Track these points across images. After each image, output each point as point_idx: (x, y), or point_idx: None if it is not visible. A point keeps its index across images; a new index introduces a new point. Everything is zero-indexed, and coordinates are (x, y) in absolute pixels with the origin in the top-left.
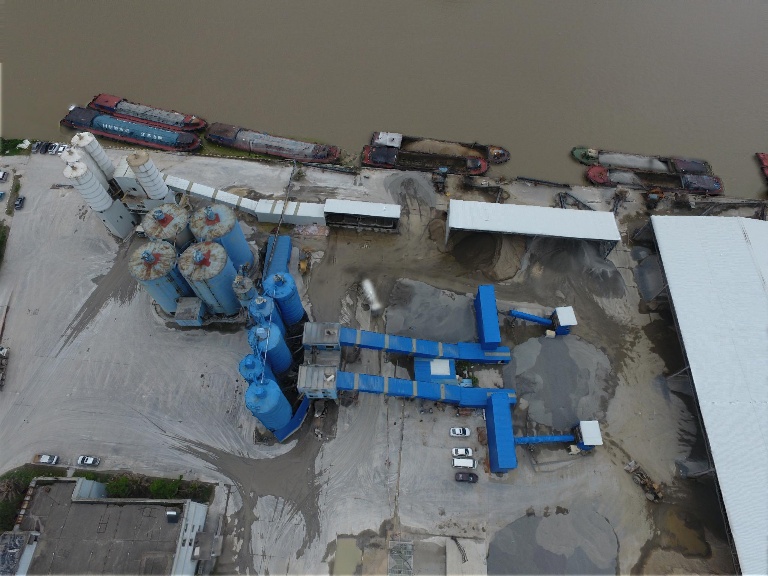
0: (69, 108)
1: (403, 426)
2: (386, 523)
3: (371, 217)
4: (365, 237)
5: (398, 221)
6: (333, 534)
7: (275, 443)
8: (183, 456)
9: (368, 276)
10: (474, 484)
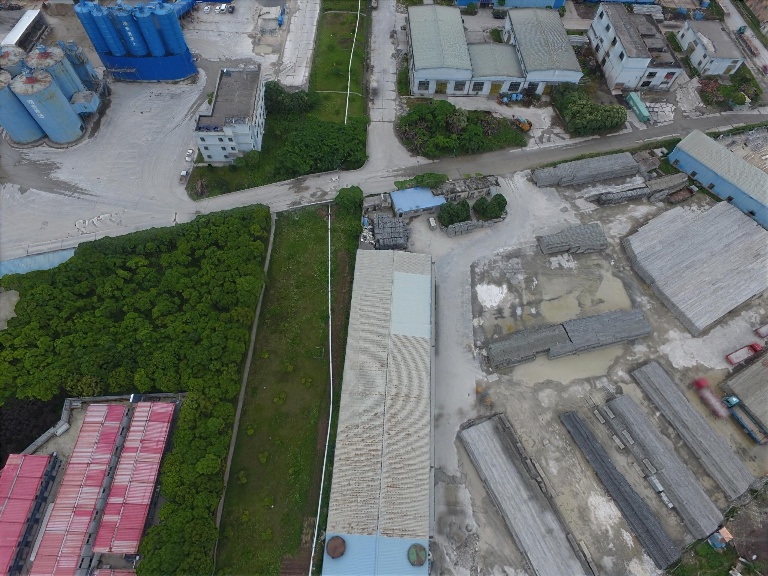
0: None
1: (199, 29)
2: (249, 36)
3: (31, 30)
4: (48, 44)
5: (42, 15)
6: (252, 53)
7: (198, 76)
8: None
9: (86, 42)
10: (235, 8)
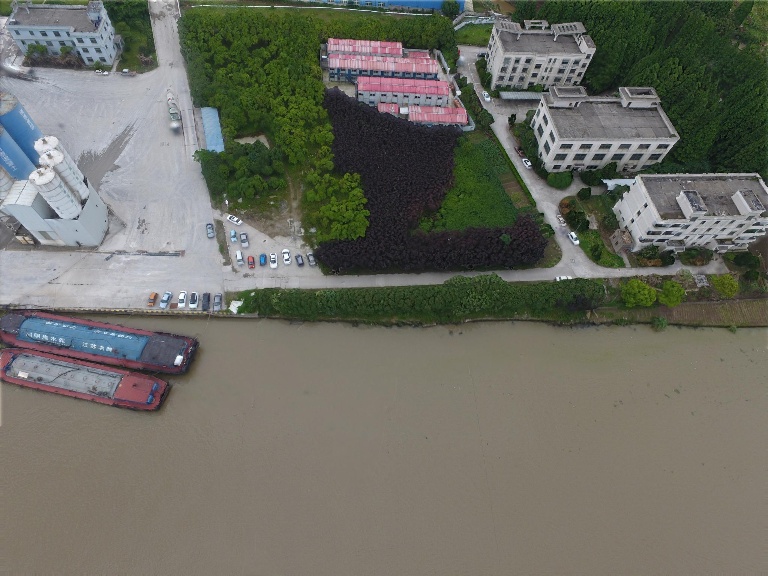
0: (182, 359)
1: None
2: None
3: None
4: None
5: None
6: None
7: None
8: (41, 76)
9: None
10: None
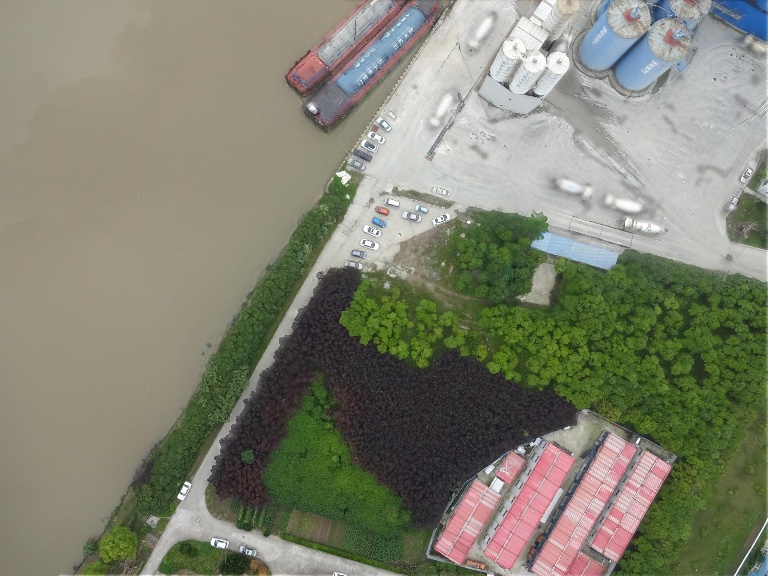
0: (313, 113)
1: None
2: None
3: None
4: None
5: None
6: None
7: None
8: None
9: None
10: None
